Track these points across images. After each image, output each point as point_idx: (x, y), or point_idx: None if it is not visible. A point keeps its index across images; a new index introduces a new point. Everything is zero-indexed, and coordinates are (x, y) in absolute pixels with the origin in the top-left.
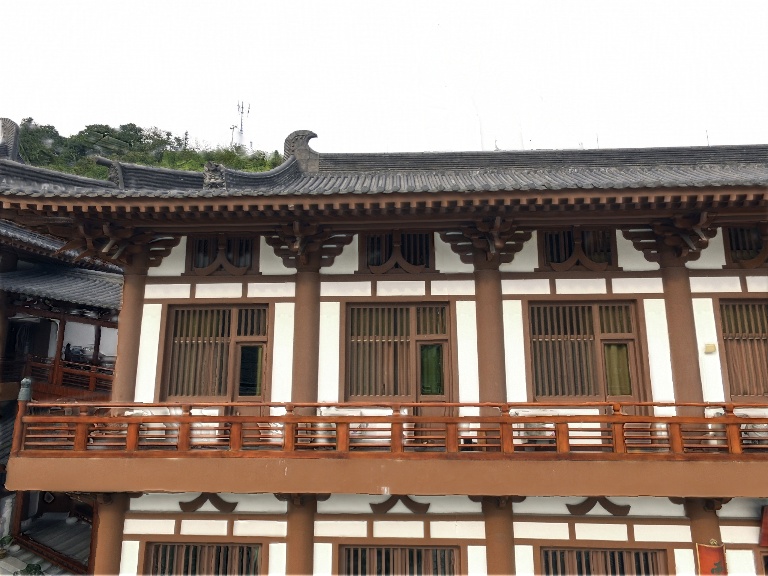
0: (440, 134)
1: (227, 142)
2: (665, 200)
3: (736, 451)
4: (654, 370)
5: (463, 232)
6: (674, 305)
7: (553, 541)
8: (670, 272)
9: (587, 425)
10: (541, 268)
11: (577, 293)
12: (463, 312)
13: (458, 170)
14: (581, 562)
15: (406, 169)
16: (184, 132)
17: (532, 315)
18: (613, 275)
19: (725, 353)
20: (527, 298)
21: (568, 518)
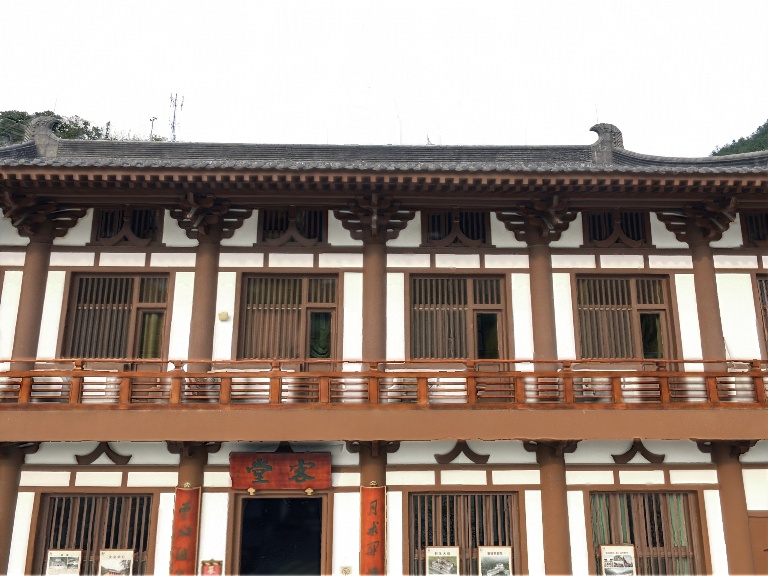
0: (361, 134)
1: (146, 134)
2: (117, 178)
3: (174, 401)
4: (173, 335)
5: (6, 207)
6: (198, 277)
7: (54, 488)
8: (200, 248)
9: (50, 379)
10: (92, 243)
11: (118, 266)
12: (10, 281)
13: (192, 160)
14: (84, 507)
15: (142, 157)
16: (105, 122)
17: (80, 285)
18: (153, 250)
19: (238, 320)
20: (71, 269)
21: (72, 467)
